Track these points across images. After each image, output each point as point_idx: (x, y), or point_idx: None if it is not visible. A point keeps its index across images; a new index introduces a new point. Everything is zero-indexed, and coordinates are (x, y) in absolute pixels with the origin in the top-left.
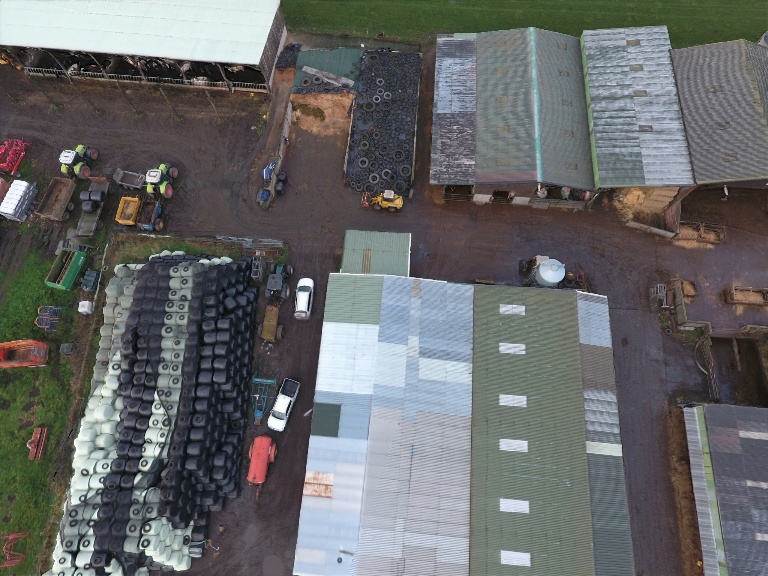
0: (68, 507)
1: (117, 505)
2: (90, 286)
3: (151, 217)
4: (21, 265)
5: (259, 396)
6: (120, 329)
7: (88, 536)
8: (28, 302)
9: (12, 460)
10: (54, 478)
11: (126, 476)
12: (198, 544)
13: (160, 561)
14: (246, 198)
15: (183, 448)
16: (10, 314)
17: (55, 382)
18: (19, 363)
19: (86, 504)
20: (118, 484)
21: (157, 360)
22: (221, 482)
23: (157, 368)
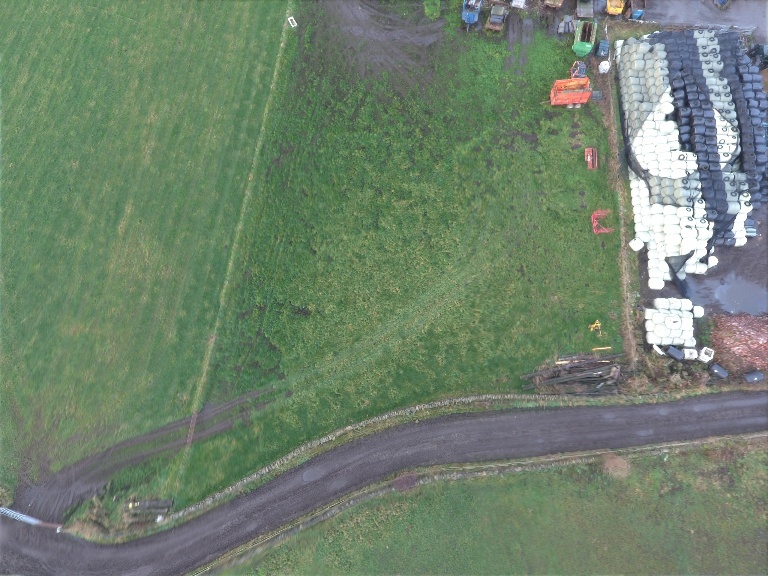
0: (667, 183)
1: (713, 180)
2: (607, 51)
3: (645, 4)
4: (532, 39)
5: (765, 135)
6: (666, 70)
7: (697, 198)
8: (548, 64)
9: (574, 169)
10: (614, 181)
11: (712, 163)
12: (751, 227)
13: (735, 231)
14: (704, 1)
15: (754, 146)
16: (536, 72)
17: (590, 119)
18: (581, 94)
19: (687, 179)
20: (708, 168)
21: (706, 91)
22: (766, 183)
23: (709, 96)
